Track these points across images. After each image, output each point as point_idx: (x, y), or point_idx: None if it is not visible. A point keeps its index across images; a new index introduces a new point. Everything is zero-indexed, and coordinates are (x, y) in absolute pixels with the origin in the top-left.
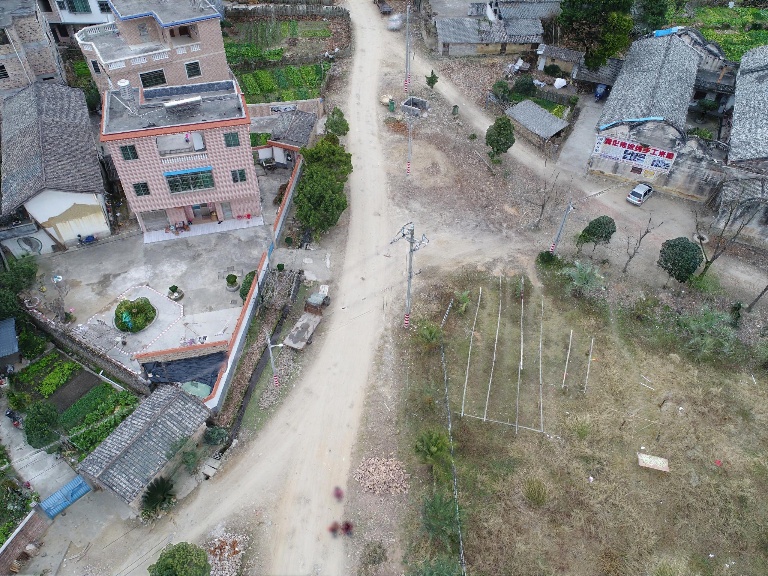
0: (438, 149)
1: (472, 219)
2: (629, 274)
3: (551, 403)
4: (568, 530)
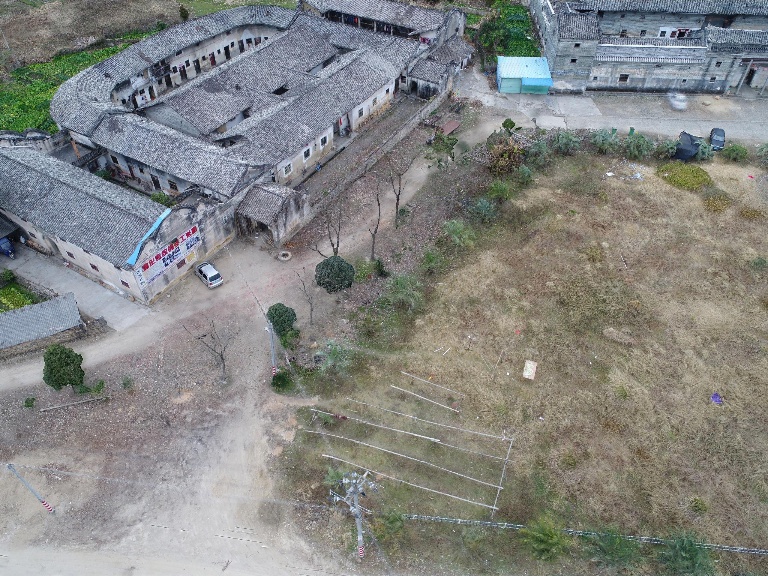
0: (9, 458)
1: (186, 443)
2: (316, 321)
3: (468, 428)
4: (592, 448)
